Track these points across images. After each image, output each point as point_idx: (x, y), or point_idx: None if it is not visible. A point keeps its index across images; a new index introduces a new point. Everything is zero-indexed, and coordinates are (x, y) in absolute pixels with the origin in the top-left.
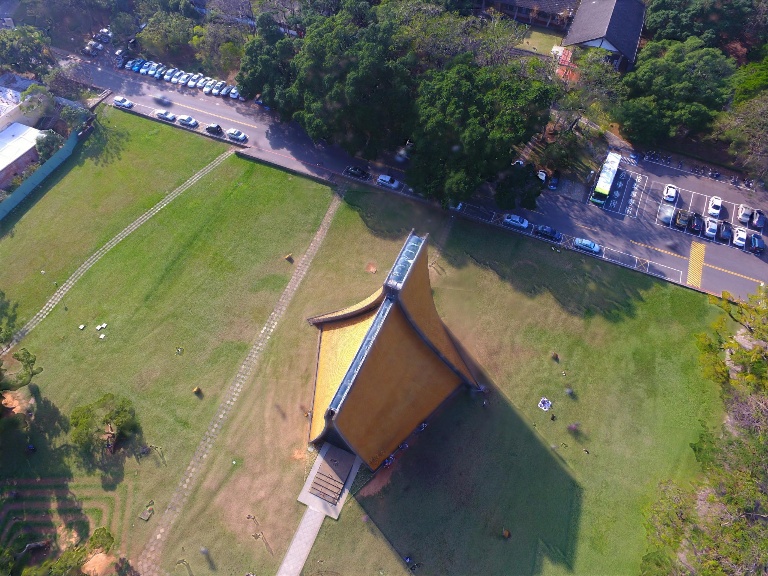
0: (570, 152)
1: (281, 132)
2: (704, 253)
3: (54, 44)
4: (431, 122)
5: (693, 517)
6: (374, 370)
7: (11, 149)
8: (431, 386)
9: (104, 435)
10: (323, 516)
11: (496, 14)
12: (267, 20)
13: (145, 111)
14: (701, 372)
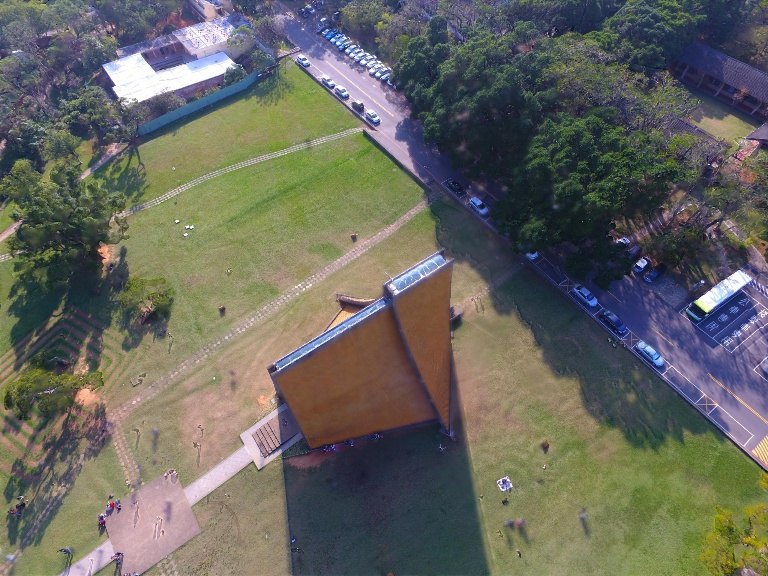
0: (688, 251)
1: (411, 127)
2: None
3: (283, 0)
4: (535, 162)
5: None
6: (342, 357)
7: (208, 71)
8: (401, 404)
9: (145, 308)
10: (250, 460)
11: (669, 79)
12: (440, 23)
13: (315, 73)
14: None
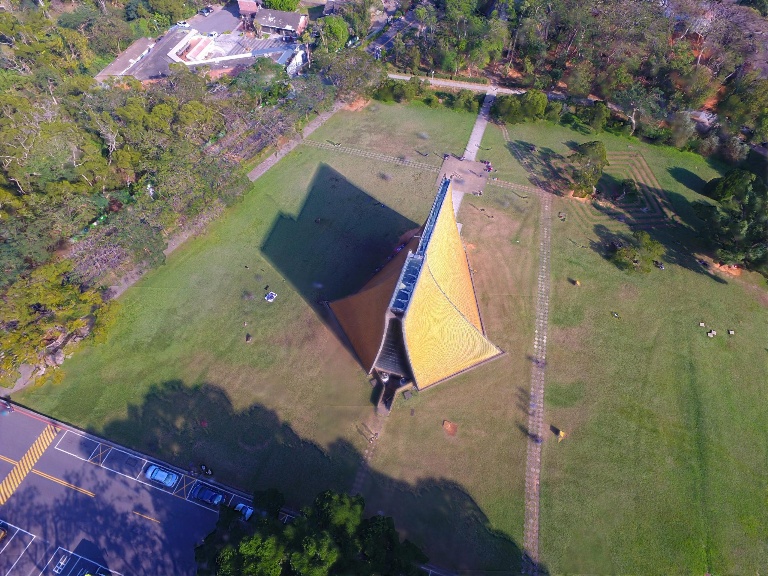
0: None
1: None
2: (3, 482)
3: None
4: None
5: (197, 204)
6: None
7: None
8: None
9: None
10: None
11: None
12: None
13: None
14: (114, 331)
